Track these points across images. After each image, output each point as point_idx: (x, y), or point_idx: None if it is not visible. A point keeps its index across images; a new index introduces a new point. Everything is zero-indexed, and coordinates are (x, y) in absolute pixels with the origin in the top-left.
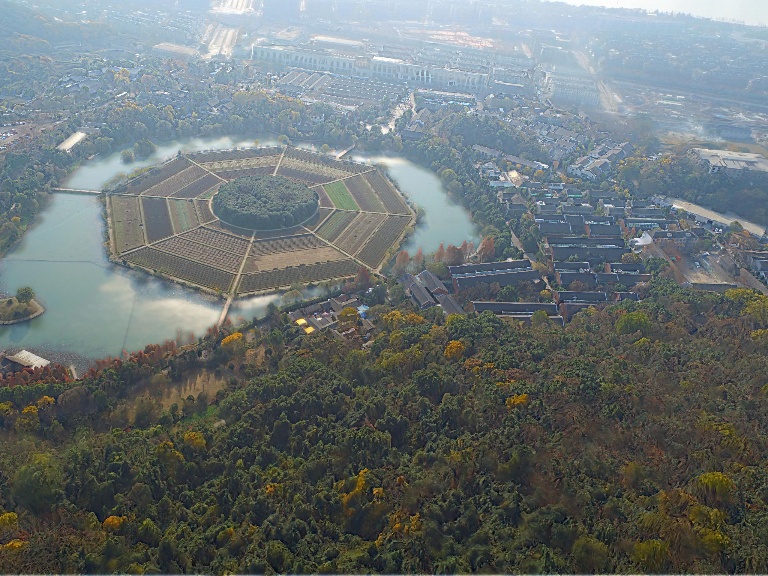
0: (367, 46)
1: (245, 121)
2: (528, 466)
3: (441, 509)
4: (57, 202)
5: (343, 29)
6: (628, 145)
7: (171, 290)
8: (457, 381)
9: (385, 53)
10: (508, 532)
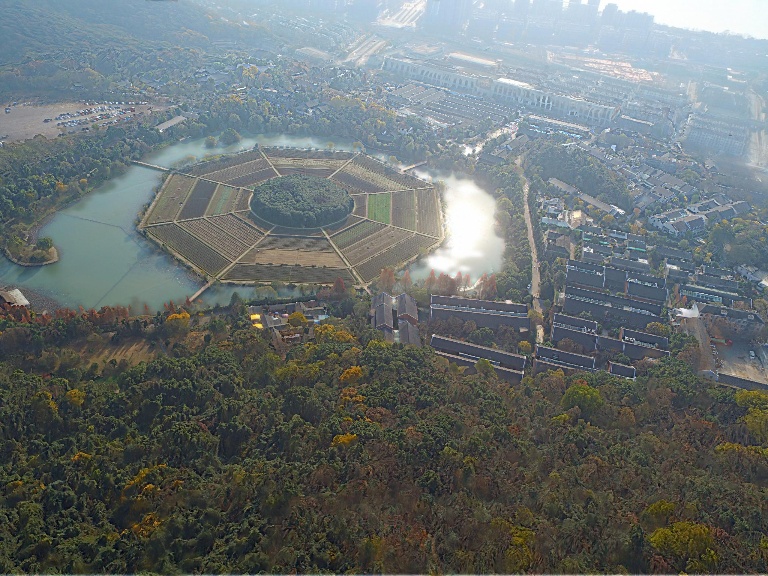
0: (500, 67)
1: (332, 124)
2: (289, 508)
3: (186, 524)
4: (129, 172)
5: (492, 49)
6: (744, 204)
7: (168, 264)
8: (320, 406)
9: (514, 75)
10: (214, 567)
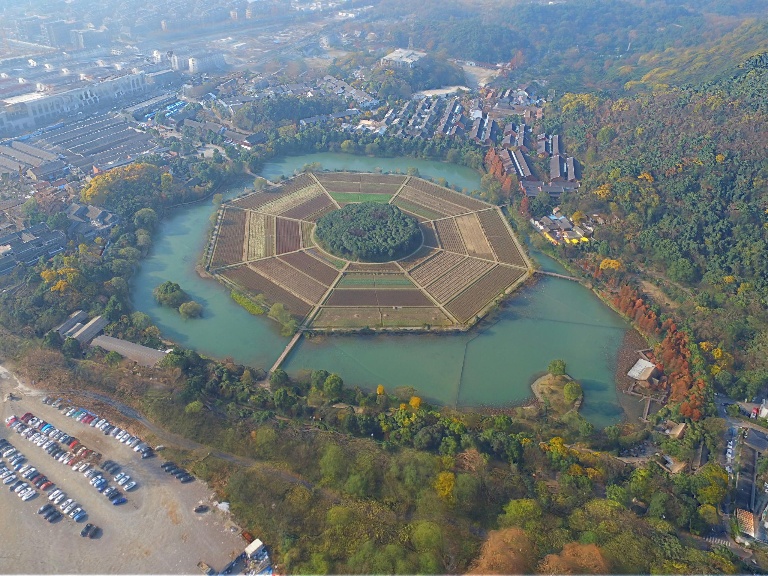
0: None
1: None
2: None
3: None
4: None
5: None
6: None
7: (521, 299)
8: None
9: (0, 93)
10: None
